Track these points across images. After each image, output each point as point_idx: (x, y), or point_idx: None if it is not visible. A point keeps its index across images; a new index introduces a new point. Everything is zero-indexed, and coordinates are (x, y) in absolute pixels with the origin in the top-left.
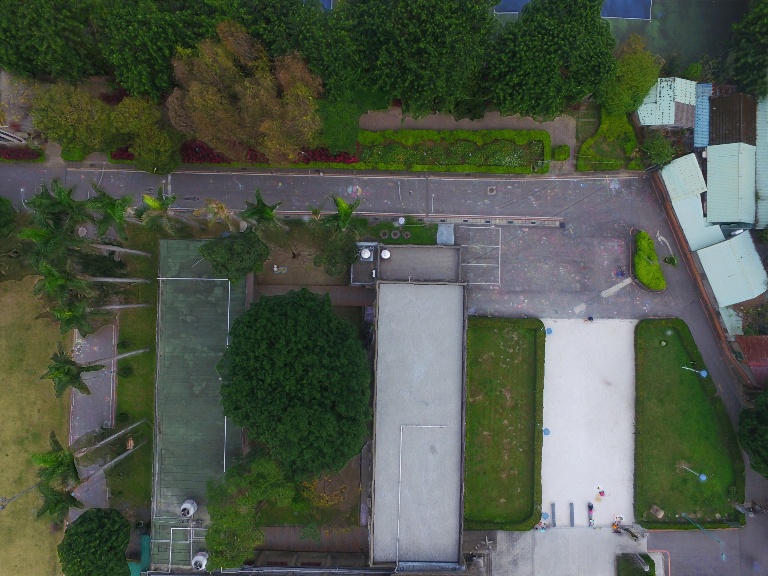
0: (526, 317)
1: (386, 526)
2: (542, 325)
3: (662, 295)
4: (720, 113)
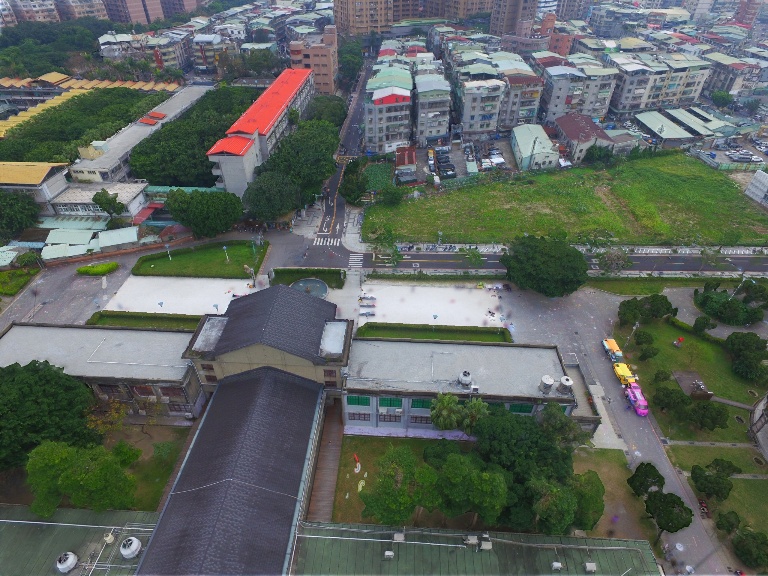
0: (88, 319)
1: (159, 374)
2: (99, 311)
3: (123, 266)
4: (30, 238)
